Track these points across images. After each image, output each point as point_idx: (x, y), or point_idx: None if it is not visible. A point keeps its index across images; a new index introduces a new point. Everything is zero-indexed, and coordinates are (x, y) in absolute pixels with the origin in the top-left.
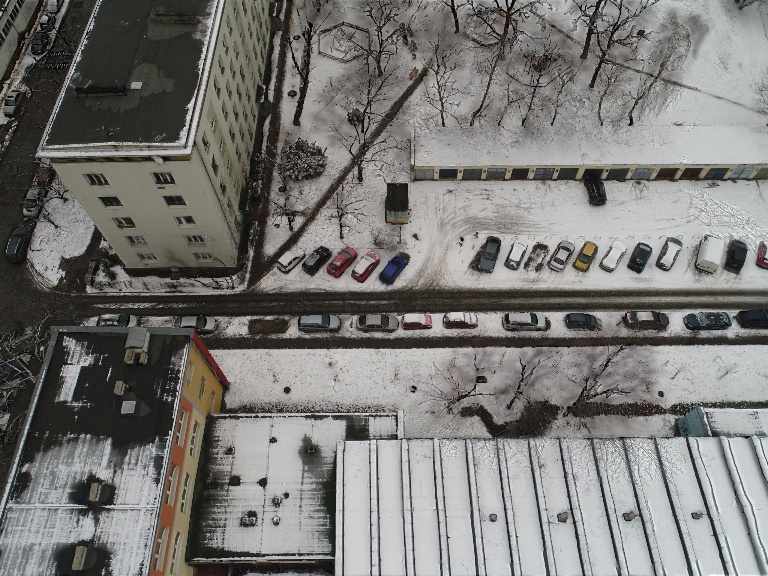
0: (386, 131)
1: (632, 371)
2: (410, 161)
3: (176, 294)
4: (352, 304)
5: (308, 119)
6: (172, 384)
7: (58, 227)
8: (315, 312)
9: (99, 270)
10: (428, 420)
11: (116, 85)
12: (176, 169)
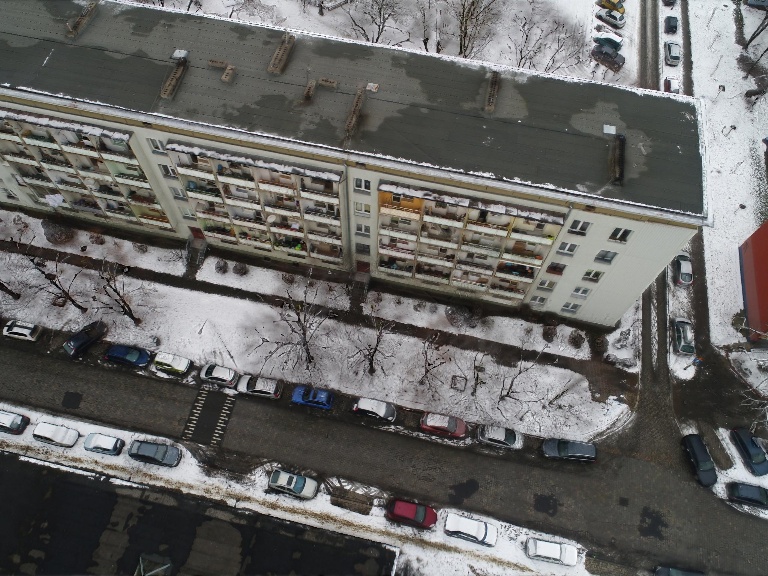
0: None
1: (710, 13)
2: None
3: None
4: None
5: None
6: None
7: None
8: None
9: None
10: (759, 124)
11: (607, 148)
12: None
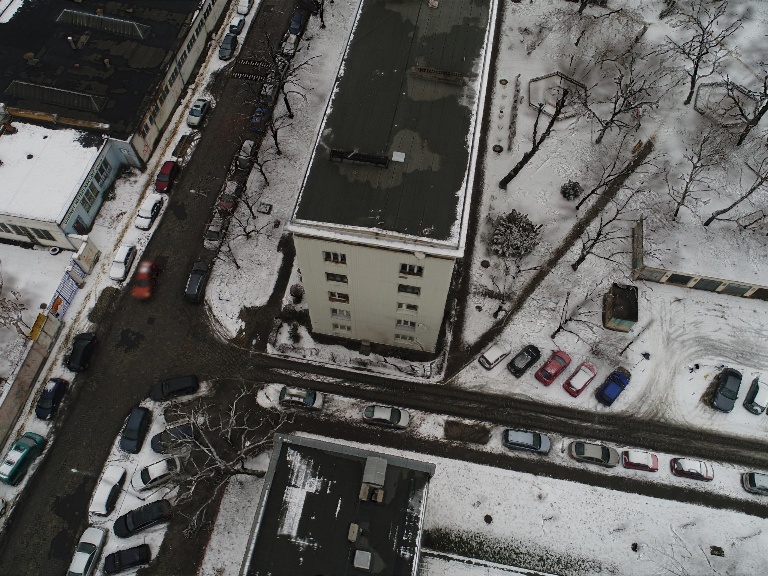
0: (649, 238)
1: None
2: (634, 255)
3: (364, 372)
4: (563, 422)
5: (515, 183)
6: (410, 535)
7: (240, 268)
8: (520, 424)
9: (282, 328)
10: None
11: (375, 152)
12: (433, 265)
